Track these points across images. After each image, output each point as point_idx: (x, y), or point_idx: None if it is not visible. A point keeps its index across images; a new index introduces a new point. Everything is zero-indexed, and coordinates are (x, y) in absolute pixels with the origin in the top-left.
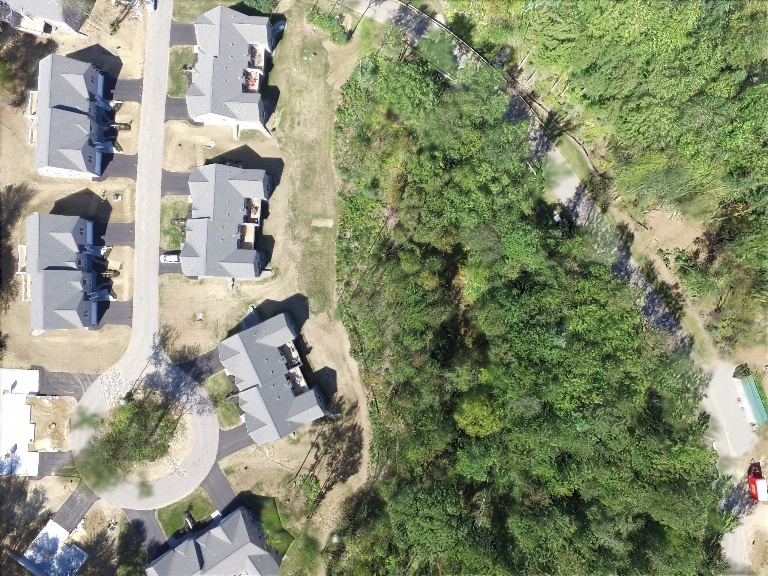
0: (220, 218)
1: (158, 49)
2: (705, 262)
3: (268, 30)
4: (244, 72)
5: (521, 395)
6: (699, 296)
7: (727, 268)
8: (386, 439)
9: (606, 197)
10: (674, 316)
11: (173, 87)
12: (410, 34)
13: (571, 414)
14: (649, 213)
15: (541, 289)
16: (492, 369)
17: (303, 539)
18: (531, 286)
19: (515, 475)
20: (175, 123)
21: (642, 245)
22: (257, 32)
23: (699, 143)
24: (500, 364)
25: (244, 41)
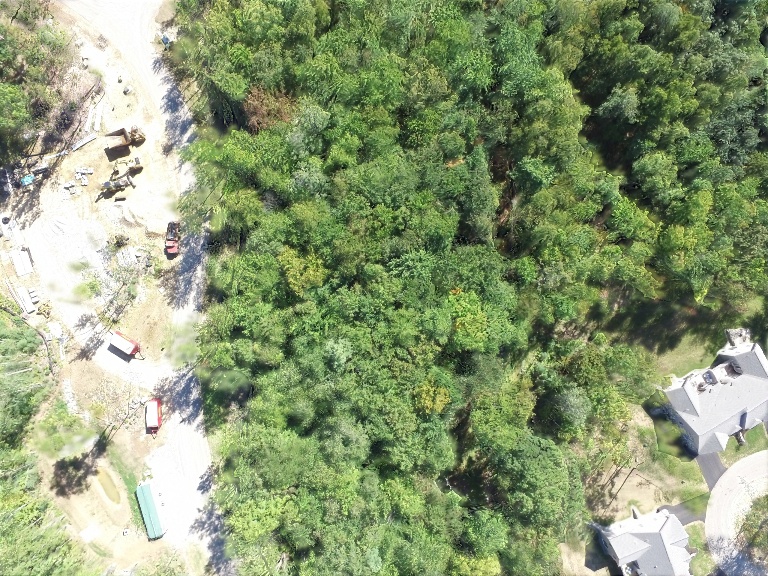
0: None
1: None
2: None
3: None
4: None
5: None
6: None
7: None
8: None
9: None
10: None
11: None
12: None
13: (382, 567)
14: None
15: None
16: None
17: None
18: None
19: (439, 492)
20: None
21: None
22: None
23: None
24: None
25: None
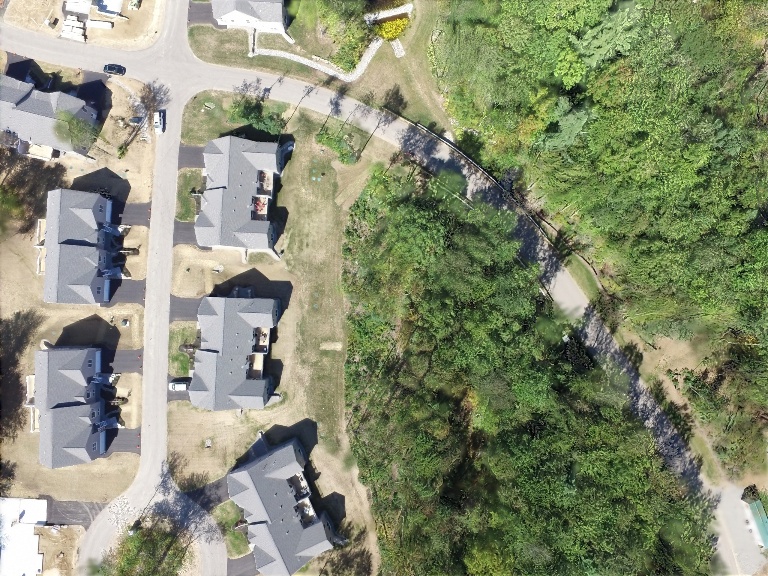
0: (229, 352)
1: (166, 172)
2: (714, 382)
3: (277, 155)
4: (253, 198)
5: (531, 542)
6: (708, 421)
7: (736, 388)
8: (394, 564)
9: (615, 317)
10: (683, 437)
11: (181, 211)
12: (419, 154)
13: (581, 559)
14: None
15: (551, 433)
16: (502, 512)
17: None
18: (541, 428)
19: None
20: (183, 247)
21: (651, 365)
22: (266, 160)
23: (710, 287)
24: (510, 509)
25: (253, 168)
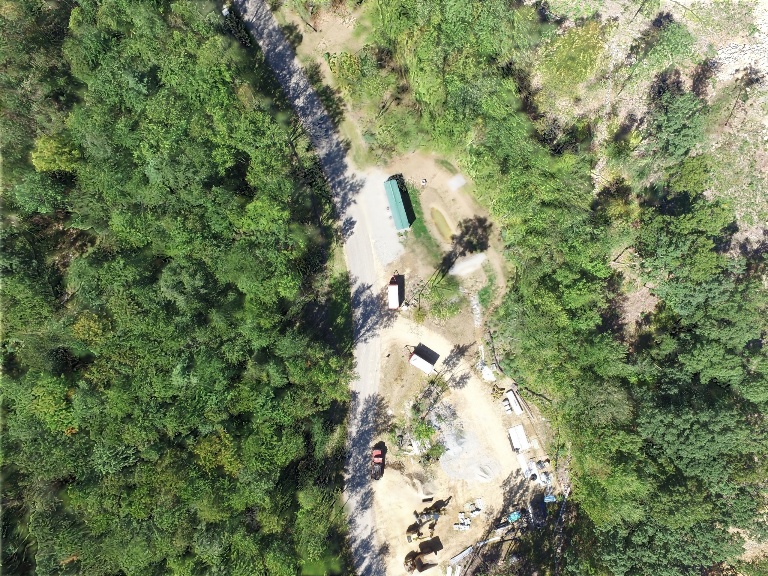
0: None
1: None
2: (372, 69)
3: None
4: None
5: (96, 137)
6: (350, 95)
7: (395, 78)
8: None
9: None
10: (333, 120)
11: None
12: None
13: (149, 163)
14: (320, 16)
15: (135, 37)
16: None
17: None
18: (130, 37)
19: None
20: None
21: (309, 47)
22: None
23: None
24: None
25: None
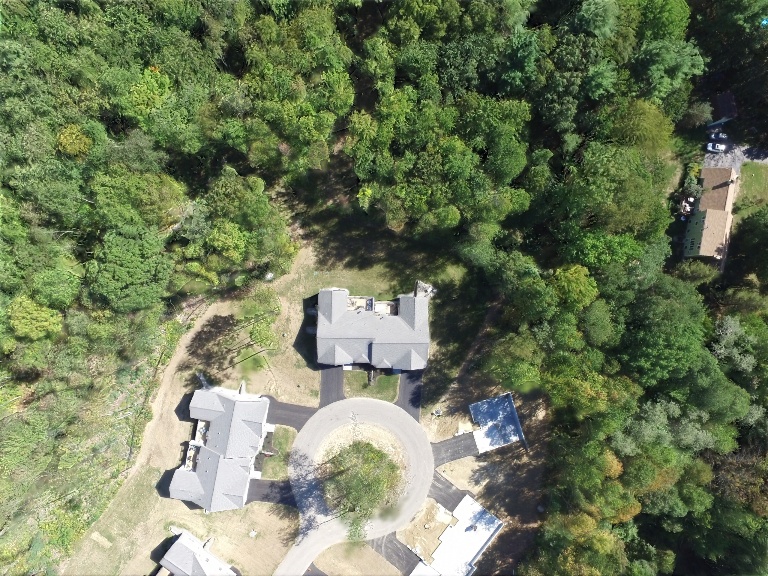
0: None
1: None
2: None
3: None
4: None
5: None
6: None
7: None
8: (172, 326)
9: None
10: None
11: None
12: None
13: None
14: None
15: None
16: None
17: (297, 294)
18: None
19: (50, 240)
20: None
21: None
22: None
23: None
24: None
25: None
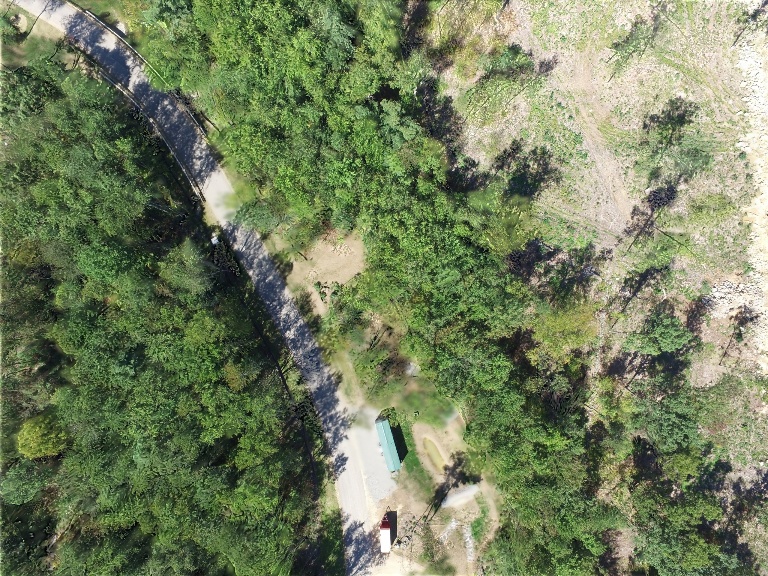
0: None
1: None
2: (363, 299)
3: None
4: None
5: (82, 420)
6: (341, 334)
7: (386, 307)
8: None
9: (269, 223)
10: (324, 352)
11: None
12: (84, 41)
13: (136, 444)
14: (311, 244)
15: None
16: None
17: None
18: None
19: None
20: None
21: (300, 276)
22: None
23: (297, 177)
24: (70, 386)
25: None
